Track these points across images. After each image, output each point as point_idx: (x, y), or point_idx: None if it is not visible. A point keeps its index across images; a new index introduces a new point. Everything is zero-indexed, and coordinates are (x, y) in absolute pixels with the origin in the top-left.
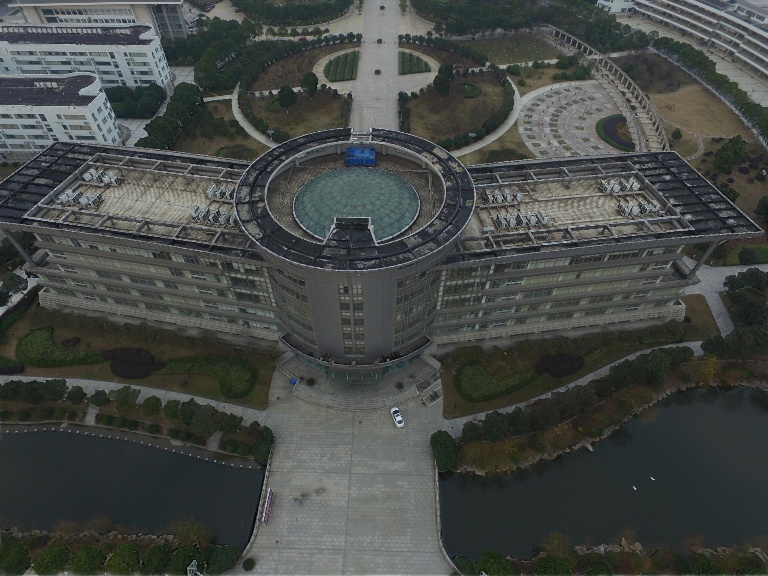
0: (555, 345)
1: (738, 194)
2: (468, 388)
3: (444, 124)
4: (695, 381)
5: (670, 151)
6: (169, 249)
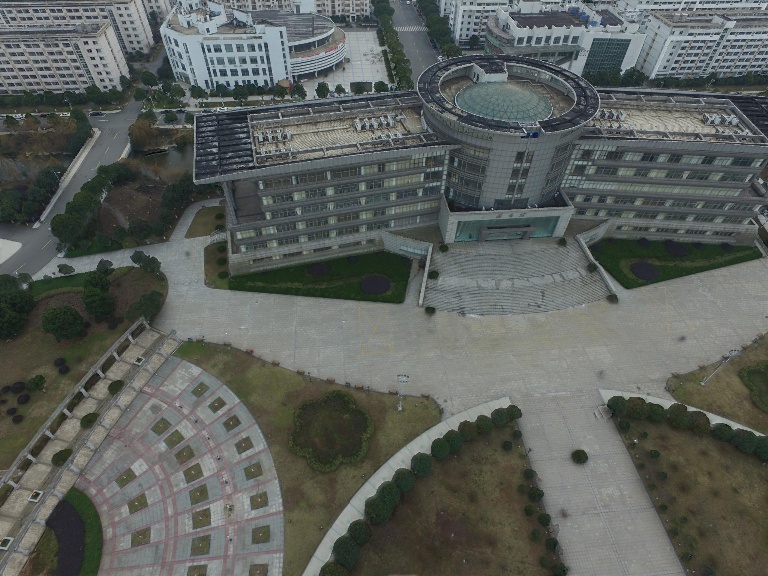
0: None
1: None
2: None
3: (458, 570)
4: None
5: (200, 180)
6: (606, 90)
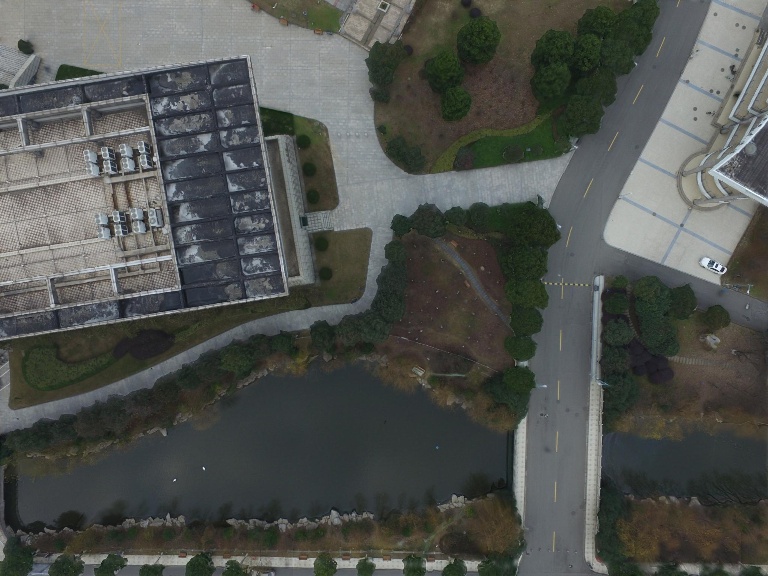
0: (136, 326)
1: (495, 35)
2: (33, 377)
3: None
4: (308, 354)
5: (238, 57)
6: None
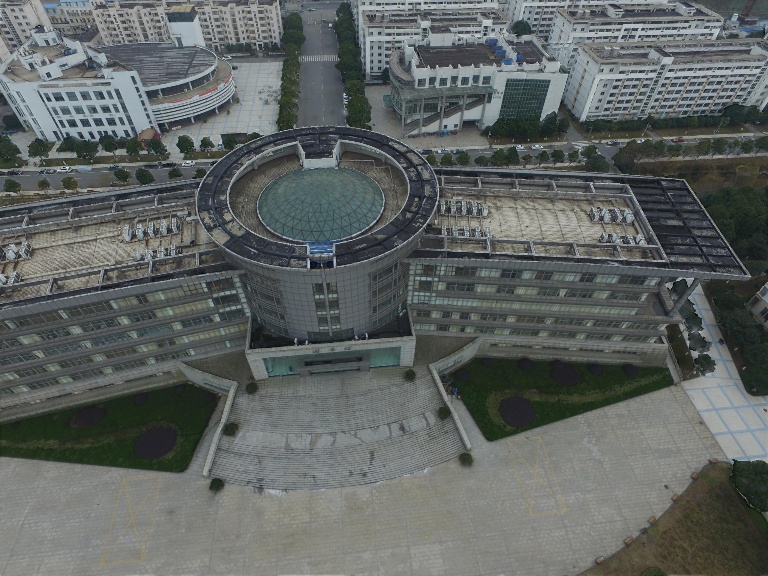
0: None
1: None
2: None
3: None
4: None
5: None
6: (474, 170)
